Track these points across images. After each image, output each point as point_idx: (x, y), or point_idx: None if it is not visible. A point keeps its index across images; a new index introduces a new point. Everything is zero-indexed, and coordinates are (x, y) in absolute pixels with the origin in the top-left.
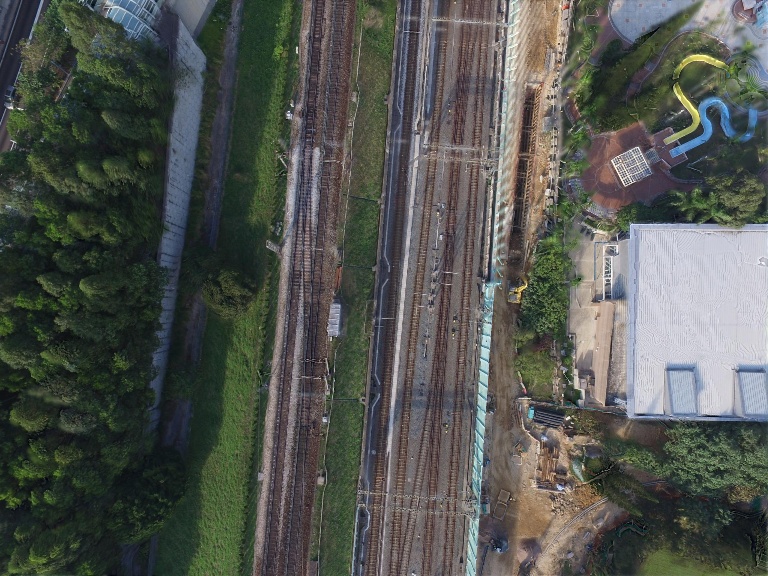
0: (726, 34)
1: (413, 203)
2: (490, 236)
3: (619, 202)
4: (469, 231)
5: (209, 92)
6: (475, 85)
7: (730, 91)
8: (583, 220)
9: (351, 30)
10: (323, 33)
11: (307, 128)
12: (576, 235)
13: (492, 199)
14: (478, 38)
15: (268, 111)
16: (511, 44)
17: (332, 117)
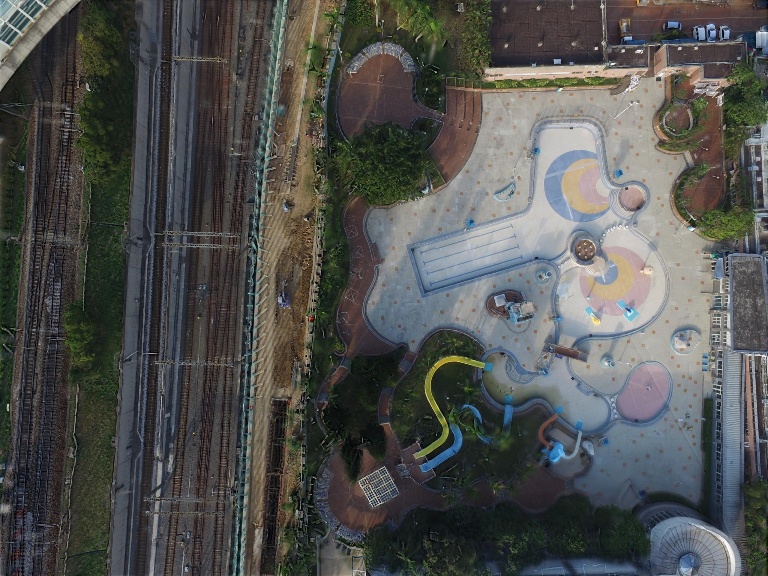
0: (481, 329)
1: (155, 535)
2: (236, 566)
3: (374, 515)
4: (216, 560)
5: None
6: (221, 402)
7: (490, 384)
8: (336, 538)
9: (66, 383)
10: (35, 389)
11: (19, 491)
12: (332, 550)
13: (239, 525)
14: (224, 352)
15: None
16: (257, 359)
17: (46, 478)
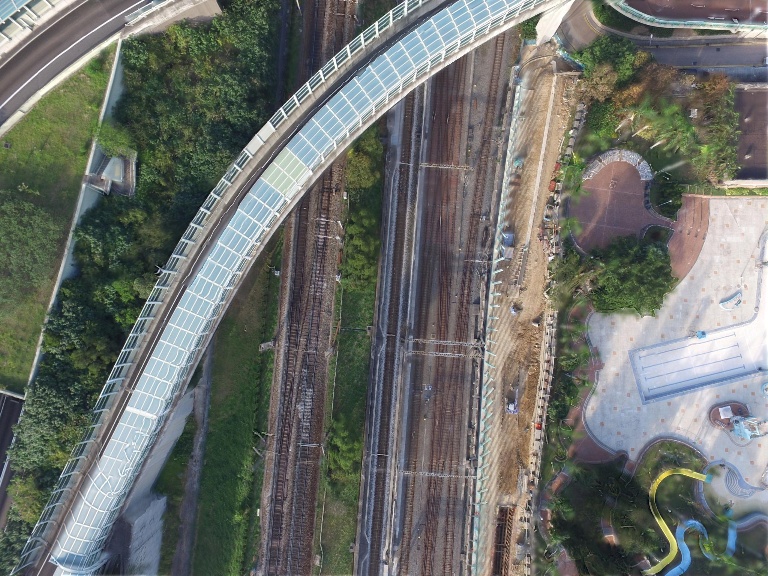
0: (703, 440)
1: None
2: None
3: None
4: None
5: (169, 529)
6: (446, 506)
7: (709, 496)
8: None
9: (314, 490)
10: (285, 495)
11: None
12: None
13: None
14: (449, 455)
15: (228, 573)
16: (482, 464)
17: None
